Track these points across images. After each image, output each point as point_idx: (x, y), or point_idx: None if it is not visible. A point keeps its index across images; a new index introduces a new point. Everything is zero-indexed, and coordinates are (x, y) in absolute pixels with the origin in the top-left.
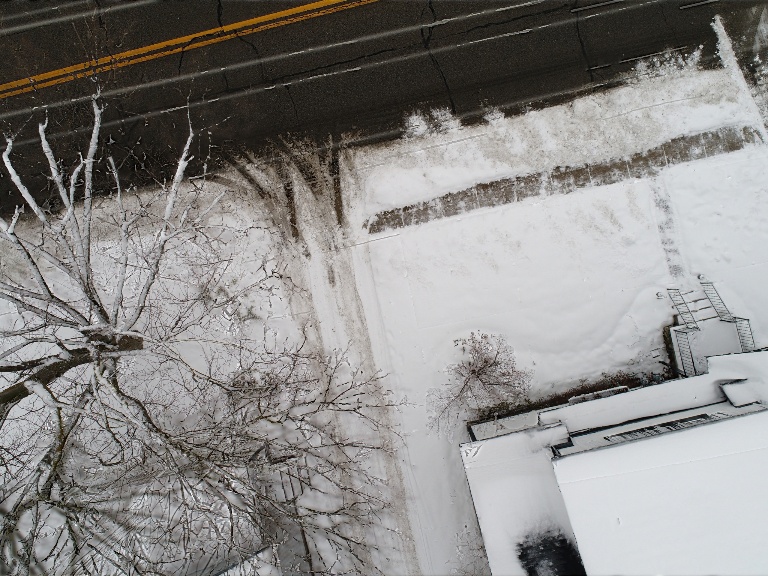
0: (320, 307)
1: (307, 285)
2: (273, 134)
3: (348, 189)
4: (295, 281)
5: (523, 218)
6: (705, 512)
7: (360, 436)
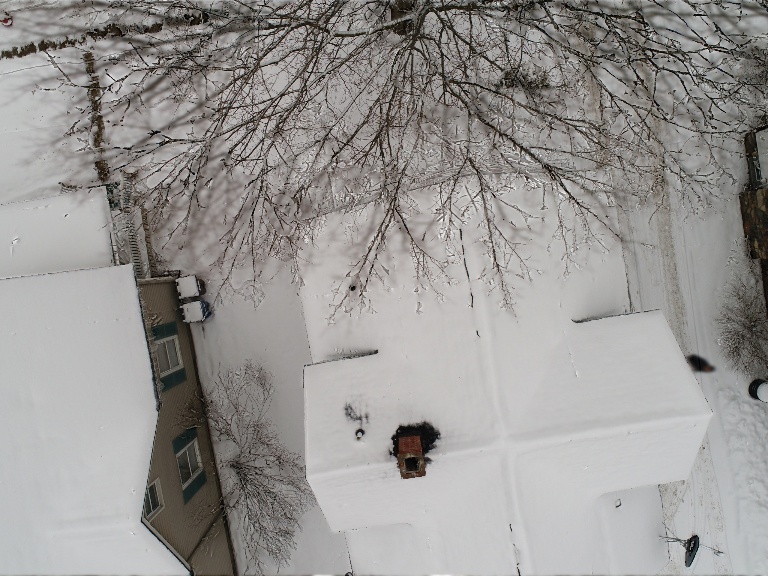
0: (596, 6)
1: None
2: None
3: None
4: None
5: None
6: None
7: None
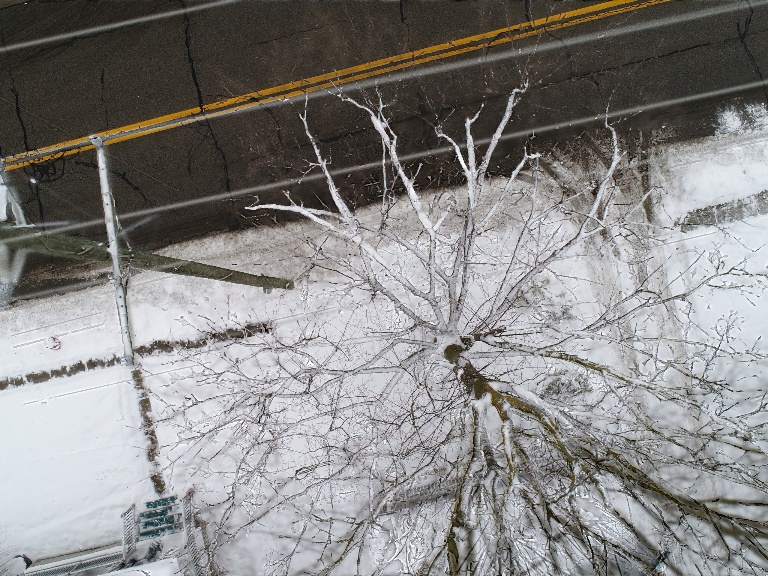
0: (631, 307)
1: (616, 284)
2: (580, 131)
3: None
4: None
5: None
6: None
7: None
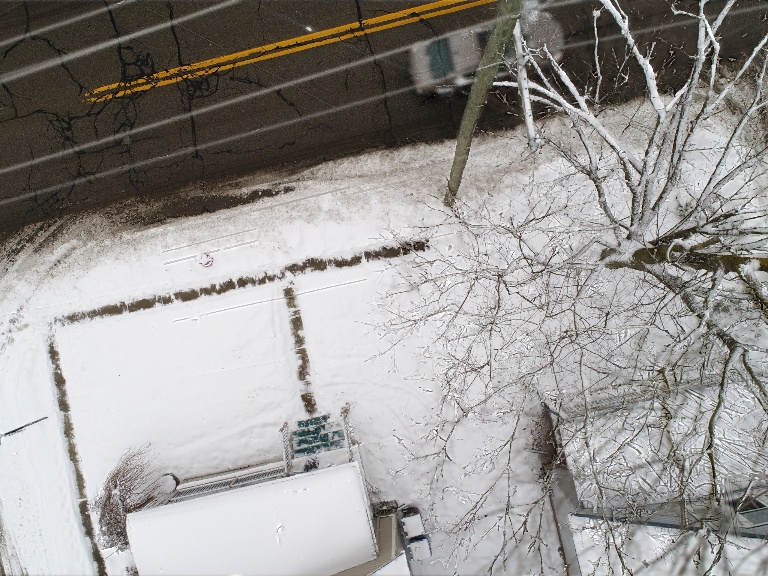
0: None
1: None
2: (748, 48)
3: None
4: None
5: None
6: None
7: None
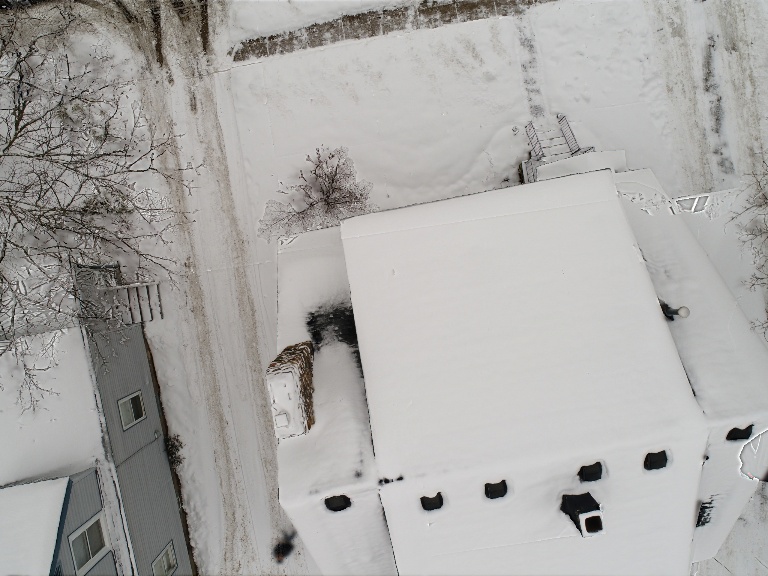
0: None
1: (169, 111)
2: None
3: (215, 15)
4: (157, 106)
5: (385, 49)
6: (480, 265)
7: (214, 266)
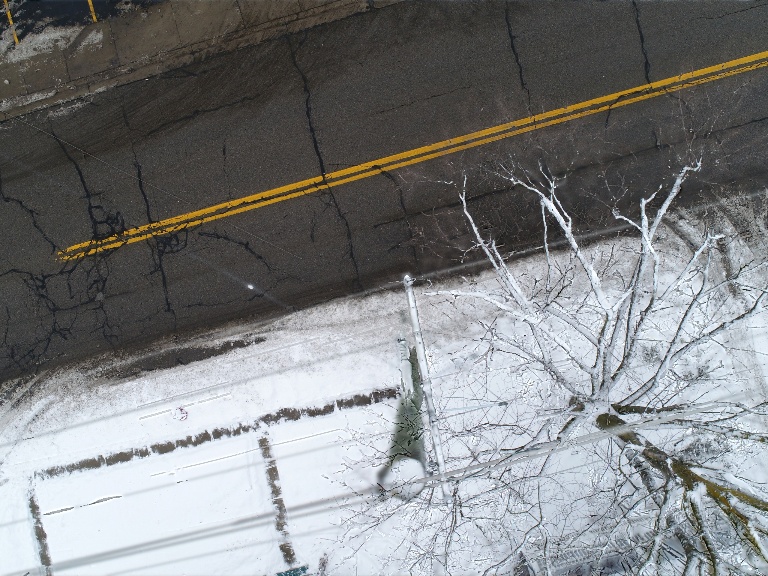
0: None
1: (749, 341)
2: (705, 189)
3: None
4: (735, 338)
5: None
6: None
7: None
